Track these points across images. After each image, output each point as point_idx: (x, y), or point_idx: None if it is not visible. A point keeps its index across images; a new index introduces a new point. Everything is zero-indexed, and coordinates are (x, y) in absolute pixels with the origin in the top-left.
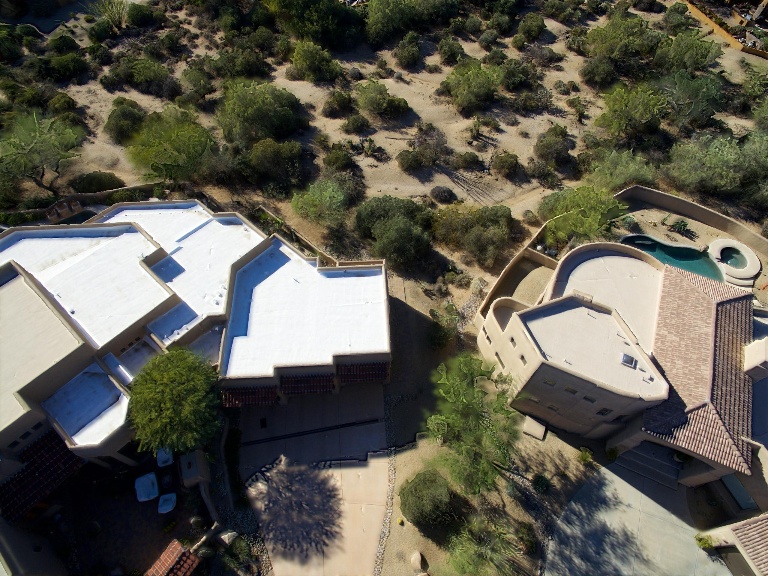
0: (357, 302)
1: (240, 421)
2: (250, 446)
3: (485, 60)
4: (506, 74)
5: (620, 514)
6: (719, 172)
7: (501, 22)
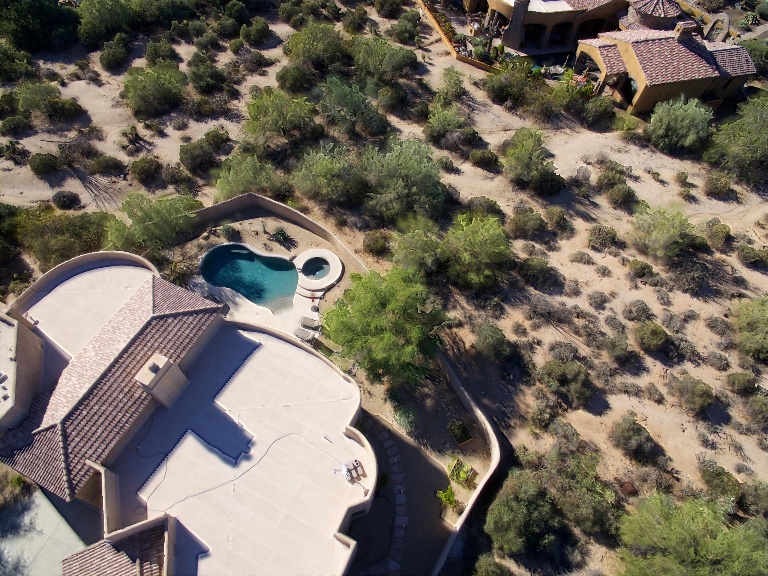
0: None
1: None
2: None
3: (192, 63)
4: (195, 78)
5: (25, 540)
6: (322, 180)
7: (225, 25)
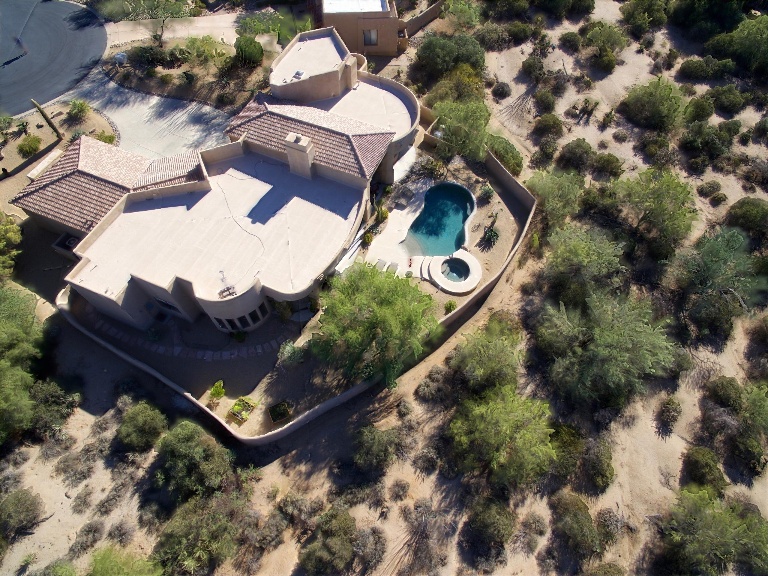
0: (362, 5)
1: (304, 4)
2: (290, 8)
3: None
4: (697, 130)
5: None
6: None
7: None
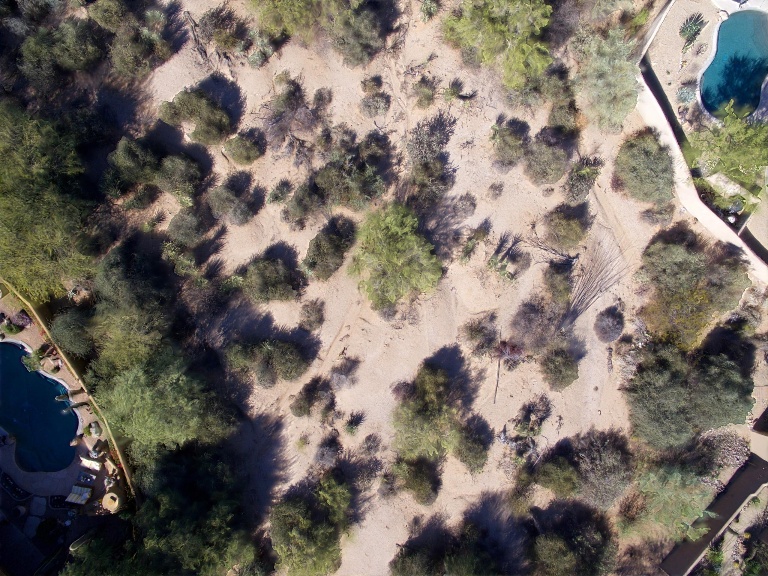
0: None
1: None
2: None
3: None
4: None
5: None
6: None
7: (183, 175)
